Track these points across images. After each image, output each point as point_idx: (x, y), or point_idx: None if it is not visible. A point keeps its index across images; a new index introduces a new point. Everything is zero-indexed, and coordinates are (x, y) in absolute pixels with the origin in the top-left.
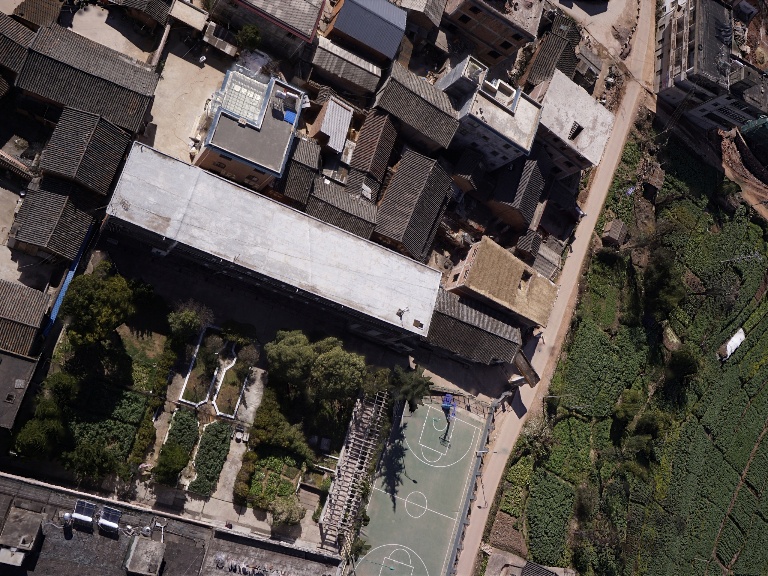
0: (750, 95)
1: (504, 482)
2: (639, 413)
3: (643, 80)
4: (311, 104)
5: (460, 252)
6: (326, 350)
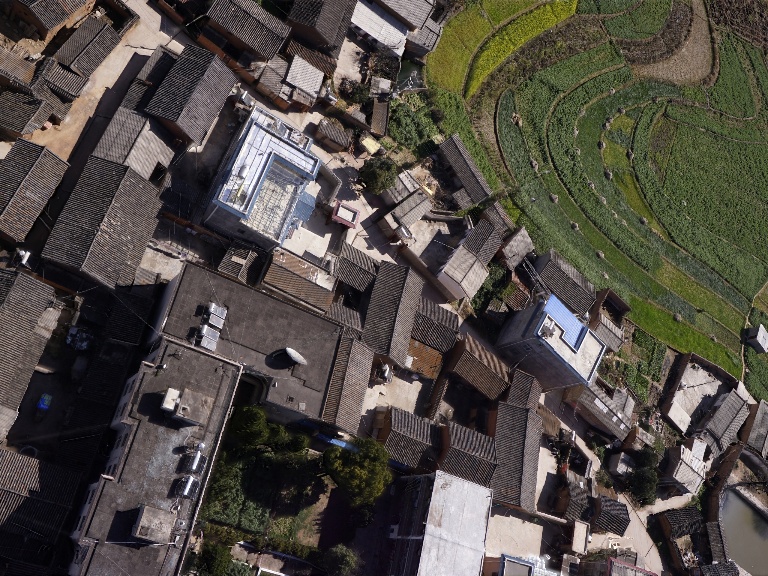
0: None
1: None
2: None
3: None
4: None
5: None
6: None
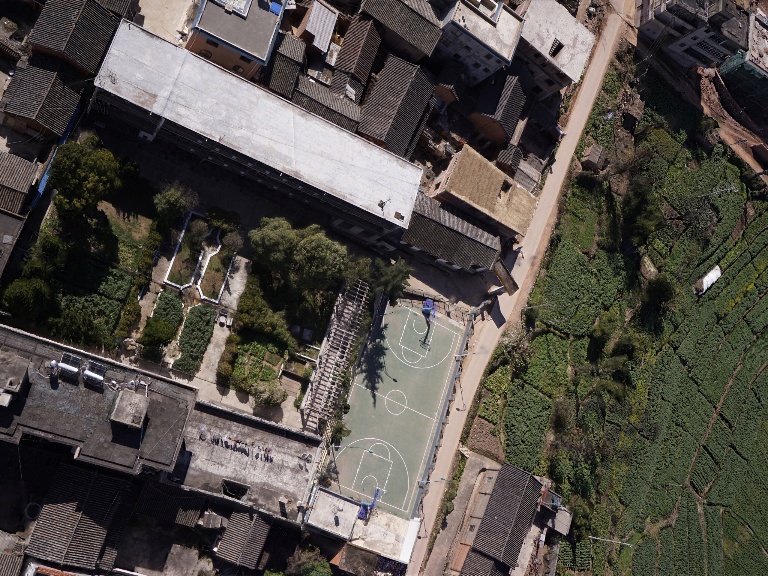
0: (728, 29)
1: (482, 389)
2: (616, 337)
3: (624, 13)
4: (297, 6)
5: (442, 162)
6: None
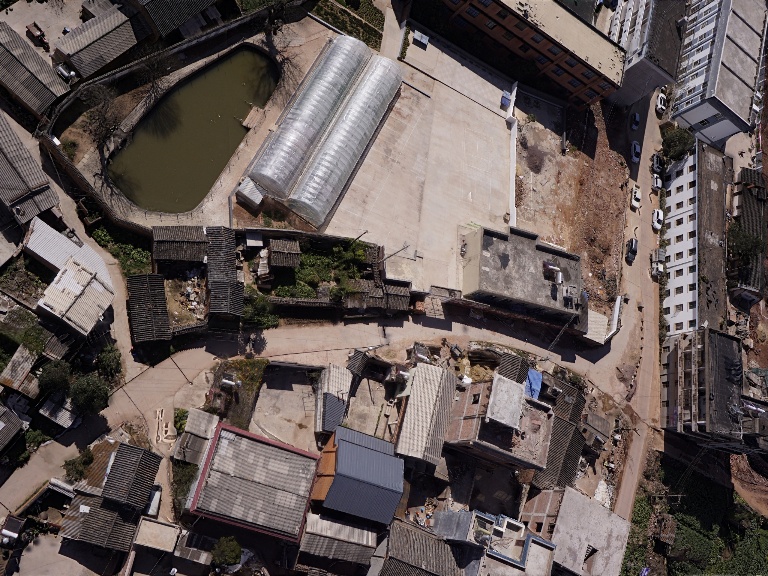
0: (763, 437)
1: None
2: None
3: (650, 418)
4: None
5: None
6: None
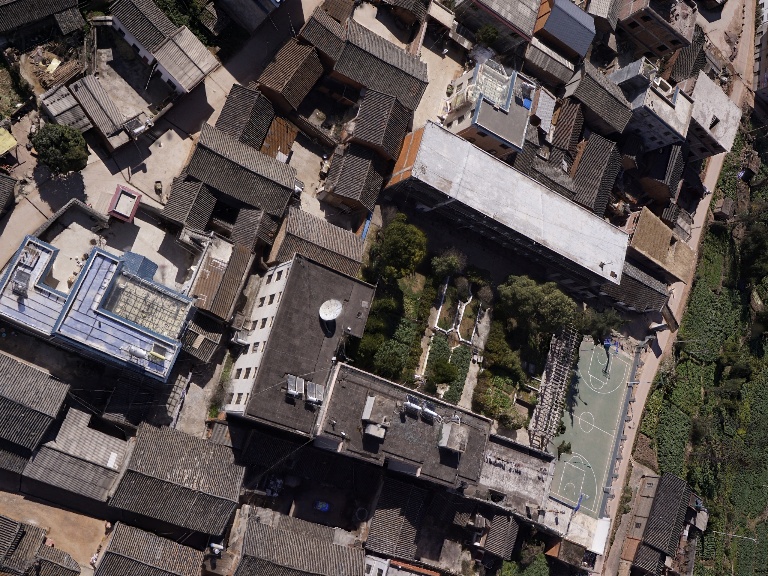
0: None
1: None
2: None
3: (745, 79)
4: None
5: (620, 219)
6: (548, 292)
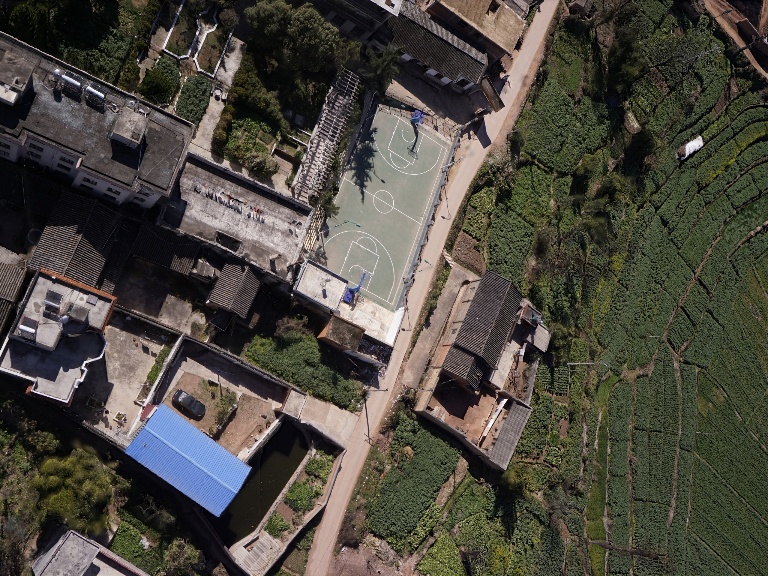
0: None
1: (467, 206)
2: (599, 183)
3: None
4: None
5: None
6: None
